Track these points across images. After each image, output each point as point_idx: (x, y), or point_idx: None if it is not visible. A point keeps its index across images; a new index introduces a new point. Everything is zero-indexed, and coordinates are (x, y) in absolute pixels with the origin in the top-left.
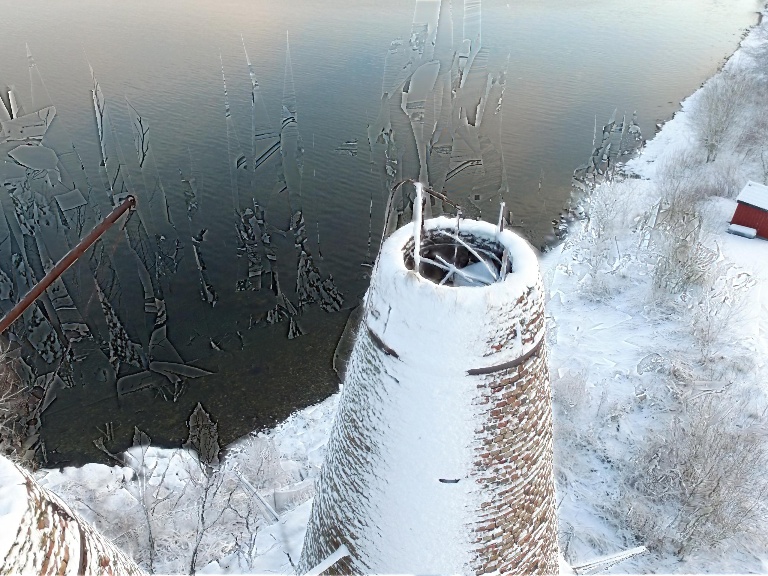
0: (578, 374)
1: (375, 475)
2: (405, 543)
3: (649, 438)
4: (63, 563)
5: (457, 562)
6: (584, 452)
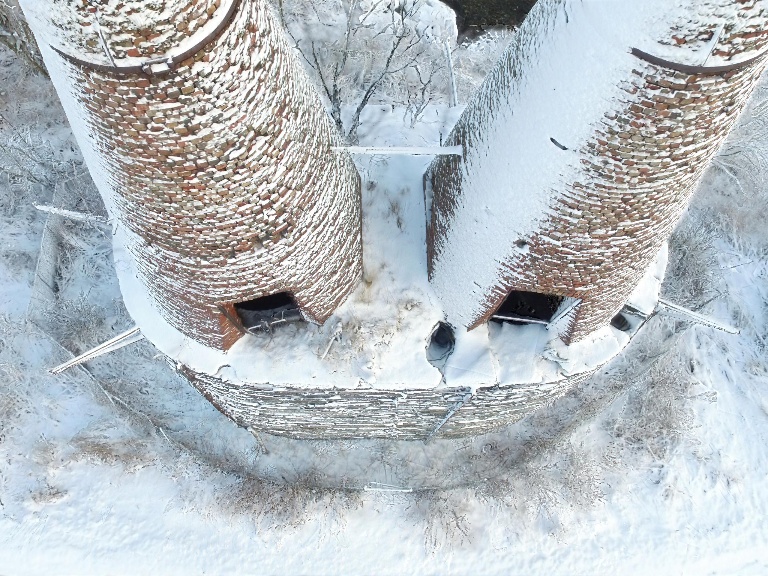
0: None
1: (508, 101)
2: (499, 172)
3: None
4: (213, 6)
5: (530, 213)
6: None
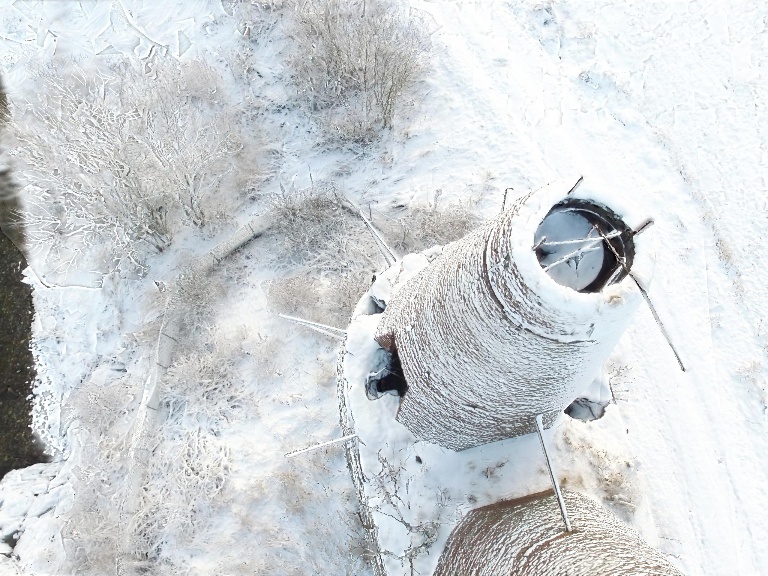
0: (194, 63)
1: None
2: None
3: (286, 62)
4: None
5: None
6: (262, 119)
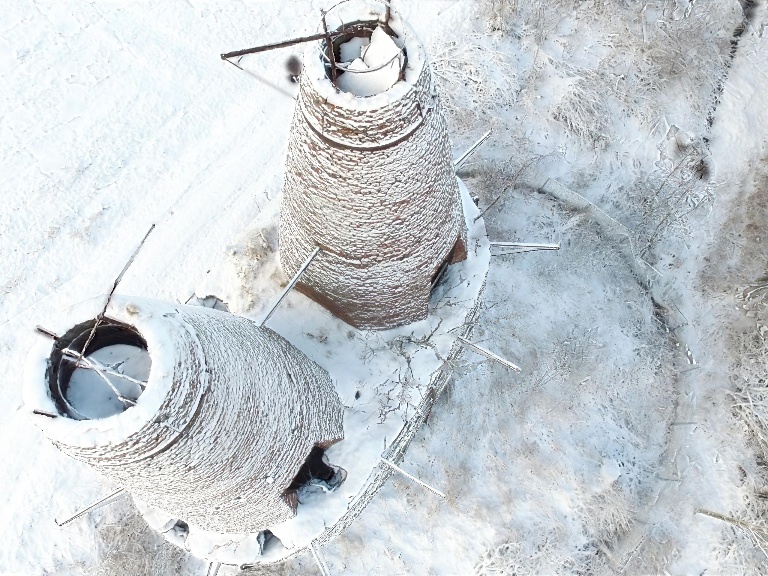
0: None
1: None
2: None
3: None
4: None
5: None
6: None
